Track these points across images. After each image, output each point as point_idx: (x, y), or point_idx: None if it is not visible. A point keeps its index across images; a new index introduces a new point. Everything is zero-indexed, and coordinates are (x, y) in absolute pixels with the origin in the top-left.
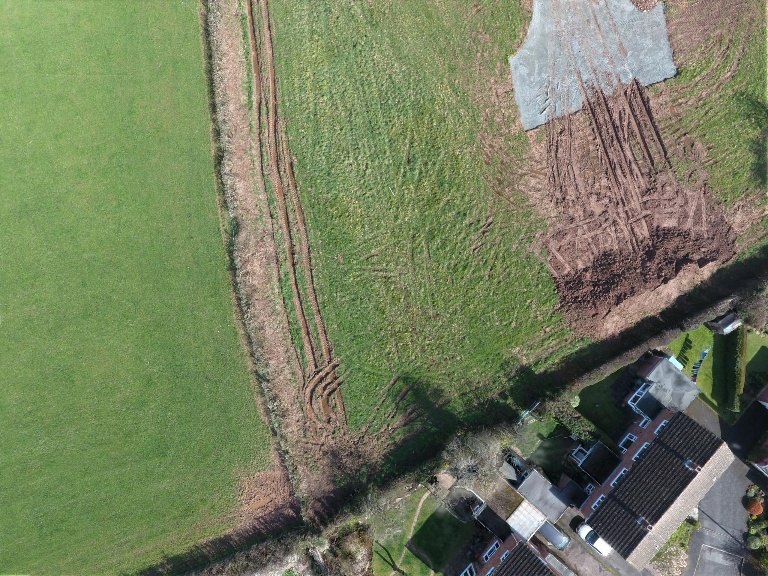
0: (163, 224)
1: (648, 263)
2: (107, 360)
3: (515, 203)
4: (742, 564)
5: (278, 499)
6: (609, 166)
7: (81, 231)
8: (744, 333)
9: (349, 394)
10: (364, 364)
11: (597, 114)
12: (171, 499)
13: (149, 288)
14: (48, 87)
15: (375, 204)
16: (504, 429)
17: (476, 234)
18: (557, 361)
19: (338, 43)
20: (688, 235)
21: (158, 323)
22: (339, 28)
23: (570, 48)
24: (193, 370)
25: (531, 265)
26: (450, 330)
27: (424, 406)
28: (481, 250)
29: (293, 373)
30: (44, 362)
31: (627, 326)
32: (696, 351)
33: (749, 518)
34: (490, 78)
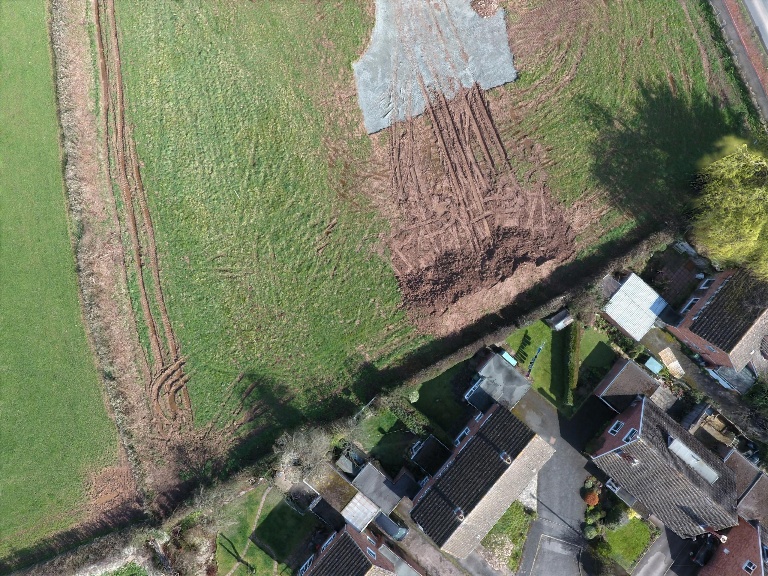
0: (12, 227)
1: (487, 262)
2: None
3: (358, 204)
4: (580, 553)
5: (125, 493)
6: (451, 168)
7: None
8: (577, 329)
9: (195, 391)
10: (210, 362)
11: (438, 117)
12: (19, 494)
13: None
14: None
15: (220, 206)
16: (336, 424)
17: (320, 235)
18: (400, 358)
19: (184, 50)
20: (527, 234)
21: (7, 323)
22: (185, 36)
23: (412, 53)
24: (41, 369)
25: (374, 265)
26: (295, 328)
27: (269, 402)
28: (325, 250)
29: (139, 371)
30: None
31: (468, 323)
32: (535, 347)
33: (587, 509)
34: (333, 83)
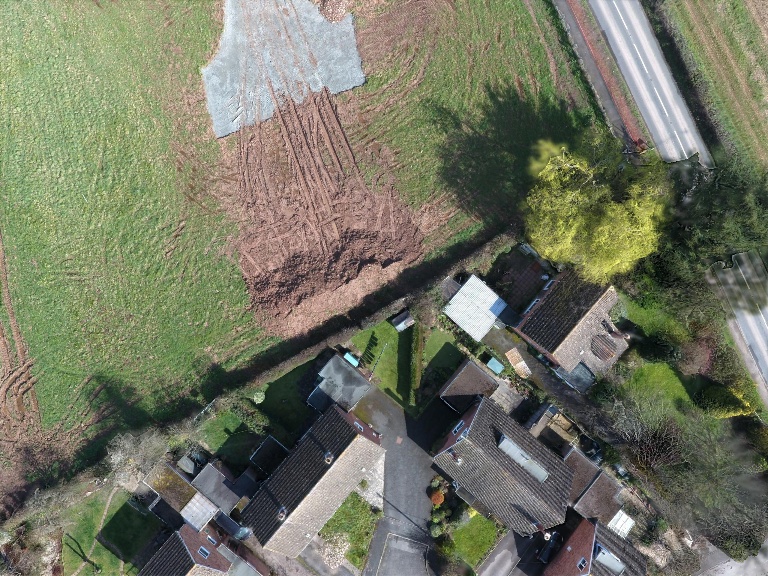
0: None
1: (333, 264)
2: None
3: (207, 208)
4: (427, 551)
5: None
6: (300, 171)
7: None
8: (419, 330)
9: (43, 393)
10: (58, 364)
11: (286, 121)
12: None
13: None
14: None
15: (68, 210)
16: (174, 425)
17: (169, 238)
18: (248, 359)
19: (32, 56)
20: (375, 237)
21: None
22: (33, 42)
23: (261, 58)
24: None
25: (223, 267)
26: (143, 330)
27: (117, 404)
28: (173, 253)
29: None
30: None
31: (316, 325)
32: (382, 348)
33: (433, 507)
34: (182, 88)
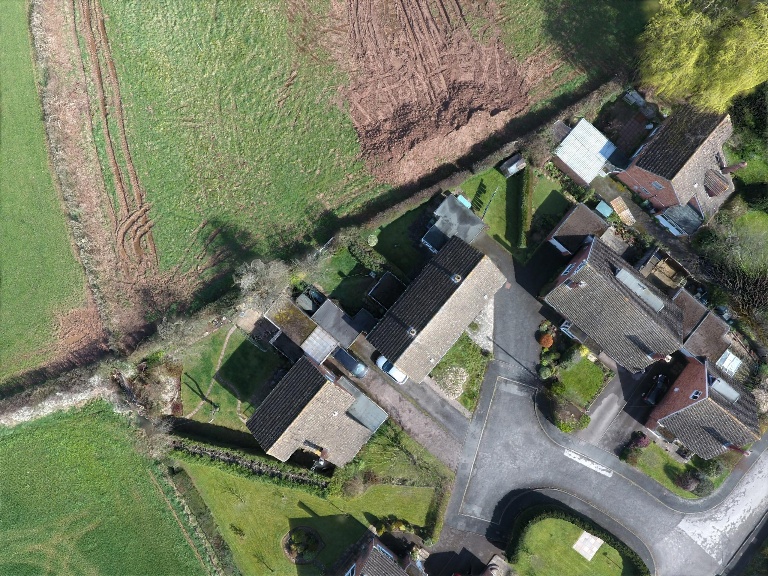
0: None
1: (443, 112)
2: None
3: (318, 58)
4: (536, 394)
5: (91, 334)
6: (408, 24)
7: None
8: (530, 174)
9: (160, 237)
10: (174, 209)
11: None
12: None
13: None
14: None
15: (183, 58)
16: (295, 259)
17: (281, 87)
18: (359, 206)
19: None
20: (482, 87)
21: None
22: None
23: None
24: (9, 213)
25: (334, 116)
26: (257, 177)
27: (232, 248)
28: (286, 102)
29: (105, 216)
30: None
31: (425, 172)
32: (490, 195)
33: (541, 351)
34: None
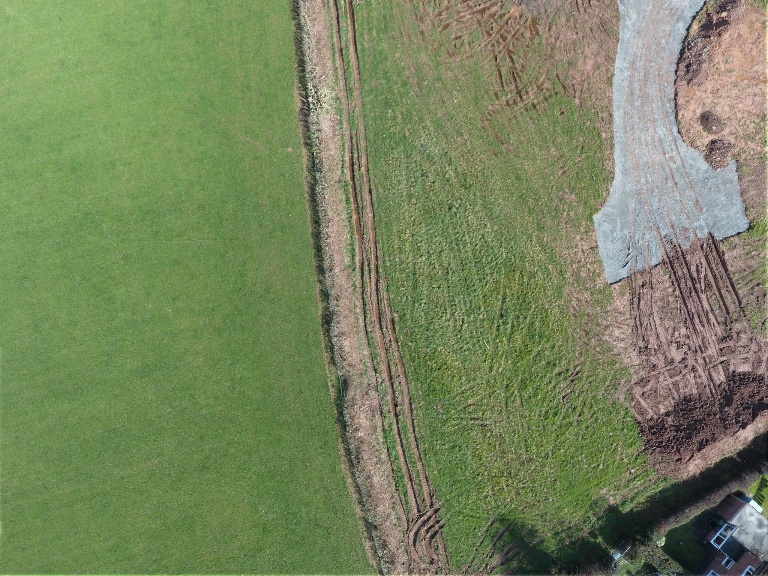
0: (275, 380)
1: (726, 408)
2: (225, 510)
3: (601, 352)
4: None
5: None
6: (687, 315)
7: (199, 389)
8: None
9: (450, 536)
10: (463, 508)
11: (676, 268)
12: None
13: (263, 441)
14: (165, 253)
15: (471, 357)
16: (600, 575)
17: (565, 382)
18: (642, 500)
19: (434, 206)
20: (762, 380)
21: (272, 474)
22: (435, 192)
23: (650, 205)
24: (305, 518)
25: (617, 410)
26: (542, 473)
27: (519, 546)
28: (570, 397)
29: (398, 518)
30: (167, 514)
31: (707, 467)
32: None
33: None
34: (576, 235)
